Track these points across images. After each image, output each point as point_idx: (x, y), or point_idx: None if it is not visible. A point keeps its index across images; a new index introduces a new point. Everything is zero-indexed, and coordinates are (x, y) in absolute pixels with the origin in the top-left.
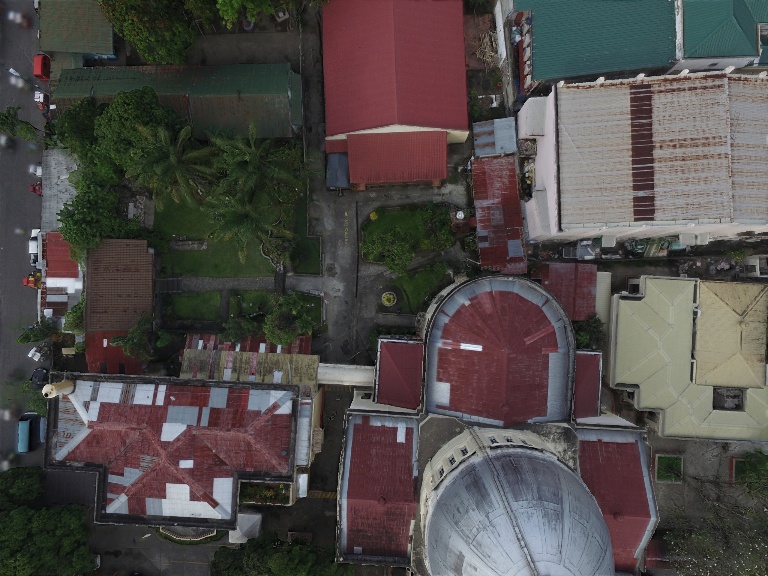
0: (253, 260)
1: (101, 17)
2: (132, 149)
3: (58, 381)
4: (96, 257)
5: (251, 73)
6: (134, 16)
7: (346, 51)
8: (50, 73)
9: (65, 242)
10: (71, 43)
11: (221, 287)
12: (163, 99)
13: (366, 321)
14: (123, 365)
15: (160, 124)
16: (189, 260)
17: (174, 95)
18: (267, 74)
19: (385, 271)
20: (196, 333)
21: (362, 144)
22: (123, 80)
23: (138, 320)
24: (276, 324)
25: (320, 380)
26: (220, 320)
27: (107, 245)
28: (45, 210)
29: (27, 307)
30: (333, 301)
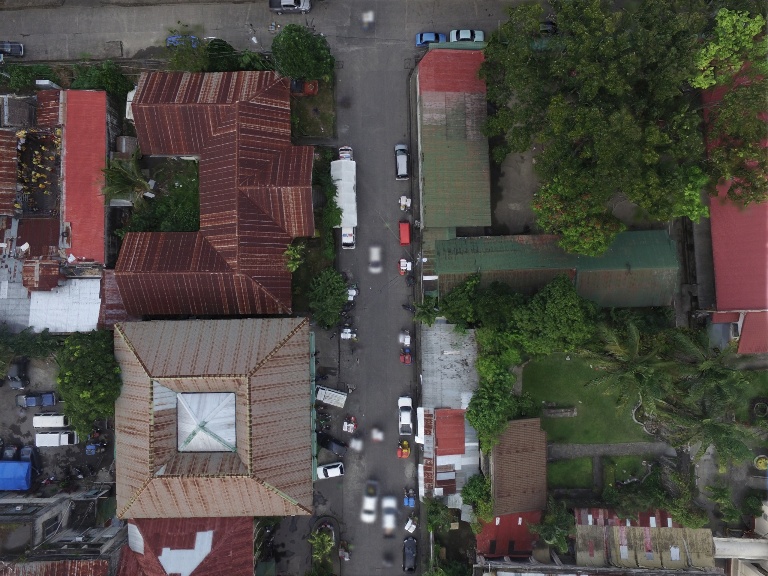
0: (624, 425)
1: (479, 189)
2: (564, 344)
3: (478, 573)
4: (500, 441)
5: (632, 243)
6: (599, 225)
7: (742, 226)
8: (422, 243)
9: (452, 419)
10: (454, 217)
11: (592, 453)
12: (549, 273)
13: (737, 484)
14: (513, 542)
15: (591, 318)
16: (560, 427)
17: (561, 269)
18: (648, 244)
19: (754, 433)
20: (584, 507)
21: (759, 319)
22: (504, 252)
23: (536, 500)
24: (688, 507)
25: (715, 555)
26: (597, 489)
27: (509, 427)
28: (427, 385)
29: (391, 475)
30: (703, 464)
